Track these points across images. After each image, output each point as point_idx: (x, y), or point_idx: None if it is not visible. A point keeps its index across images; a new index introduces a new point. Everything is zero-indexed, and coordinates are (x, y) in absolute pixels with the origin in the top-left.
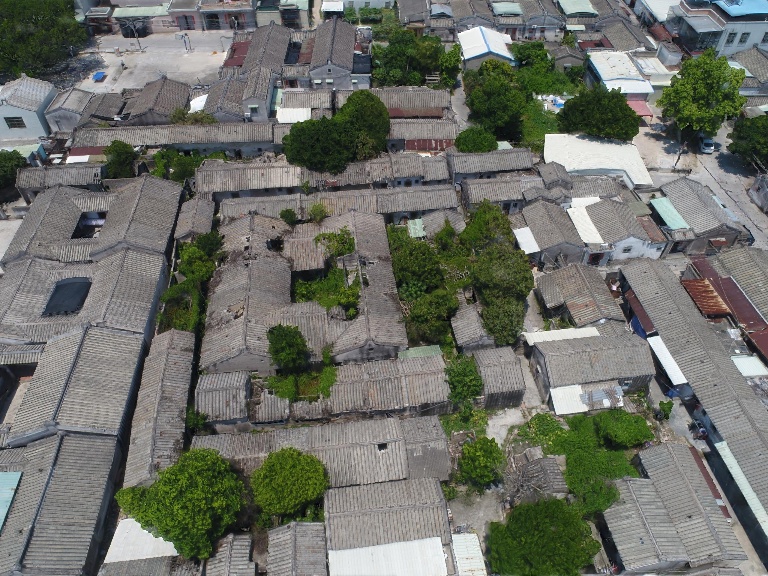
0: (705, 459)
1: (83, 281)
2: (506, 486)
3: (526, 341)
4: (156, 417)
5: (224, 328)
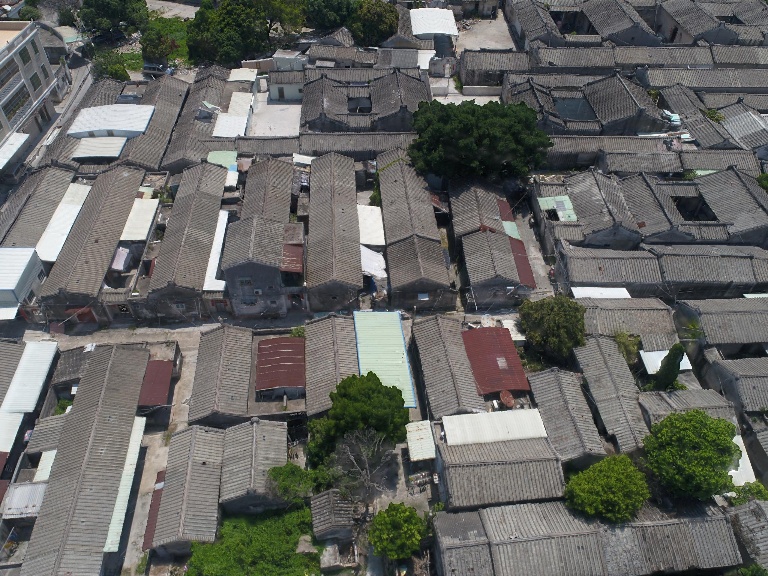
0: (123, 568)
1: None
2: (367, 536)
3: None
4: None
5: None
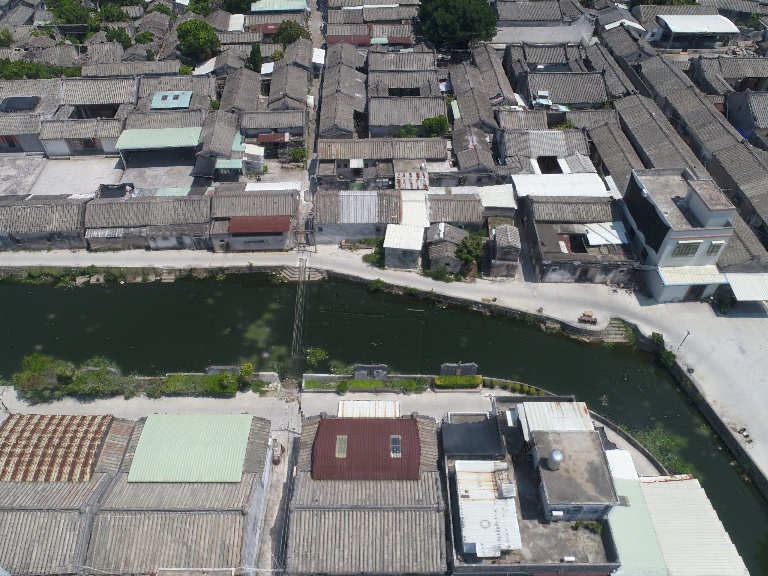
0: None
1: (10, 98)
2: None
3: (148, 2)
4: (144, 61)
5: (91, 55)
